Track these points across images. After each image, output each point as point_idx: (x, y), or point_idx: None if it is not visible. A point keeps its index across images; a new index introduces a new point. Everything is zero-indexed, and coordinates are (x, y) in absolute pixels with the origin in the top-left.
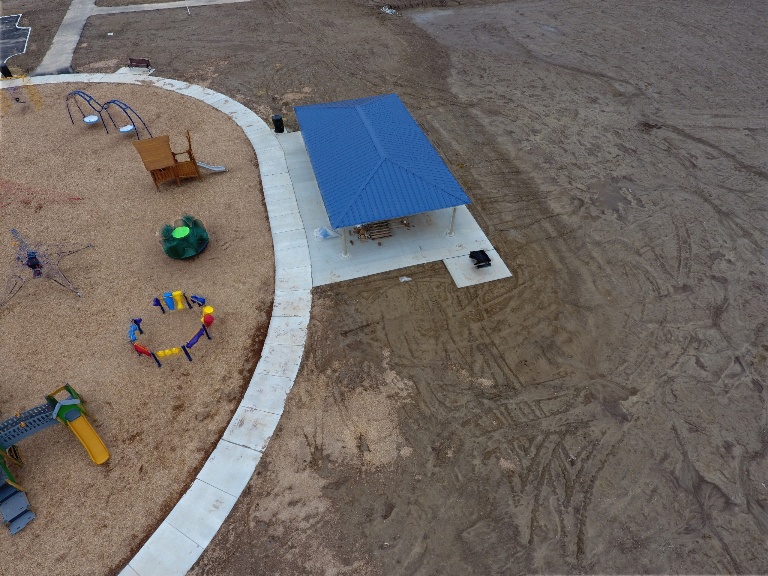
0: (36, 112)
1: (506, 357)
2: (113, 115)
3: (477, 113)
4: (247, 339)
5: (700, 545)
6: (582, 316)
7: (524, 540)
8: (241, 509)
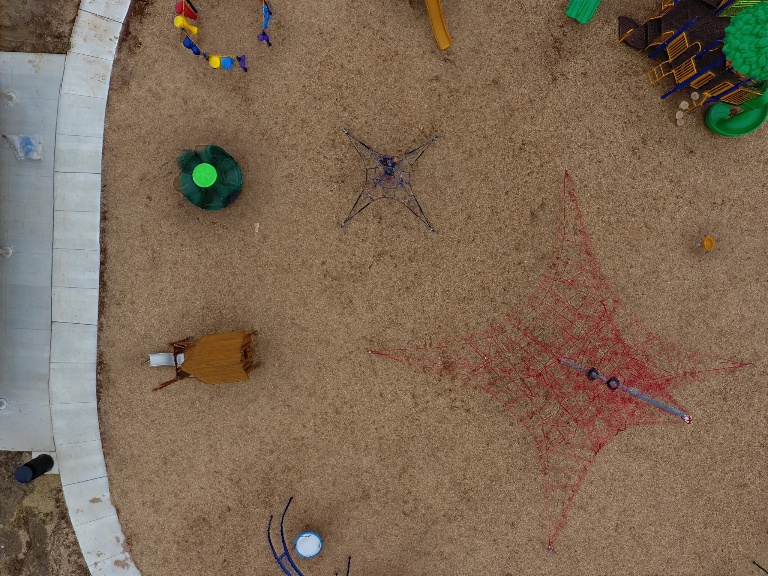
0: None
1: None
2: None
3: None
4: (156, 1)
5: None
6: None
7: None
8: None
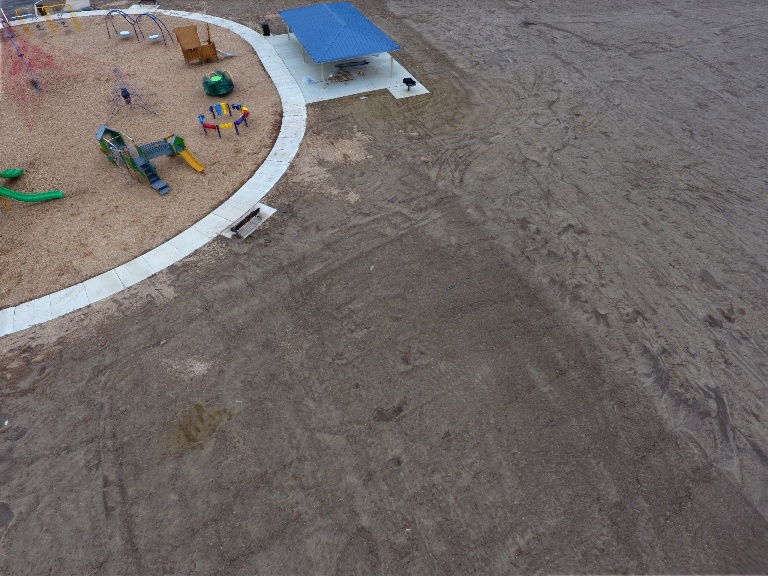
0: (77, 33)
1: (426, 125)
2: (138, 32)
3: (409, 22)
4: (270, 126)
5: (521, 177)
6: (471, 107)
7: (433, 180)
8: (283, 180)
